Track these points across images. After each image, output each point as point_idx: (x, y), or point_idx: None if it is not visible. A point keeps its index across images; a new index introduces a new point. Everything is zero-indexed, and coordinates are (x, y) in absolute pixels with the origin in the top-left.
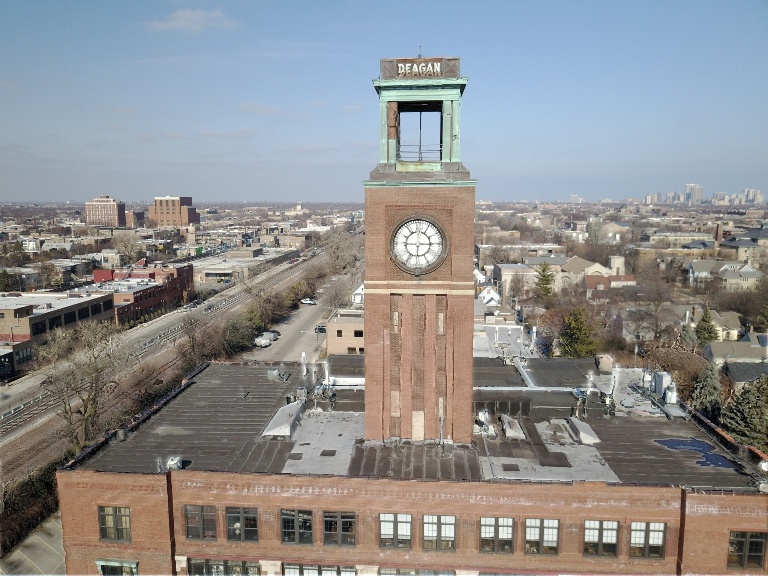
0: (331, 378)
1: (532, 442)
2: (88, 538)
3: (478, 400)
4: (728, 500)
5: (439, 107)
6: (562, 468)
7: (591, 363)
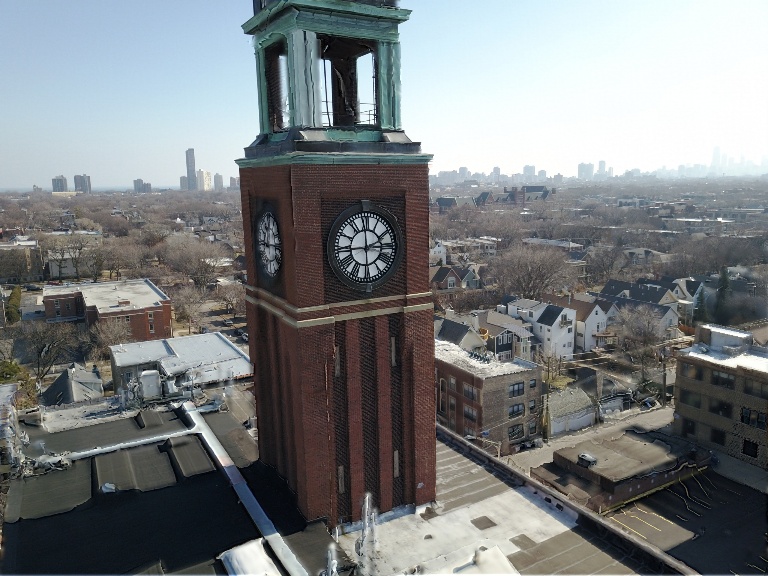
0: None
1: None
2: None
3: None
4: None
5: None
6: None
7: (27, 428)
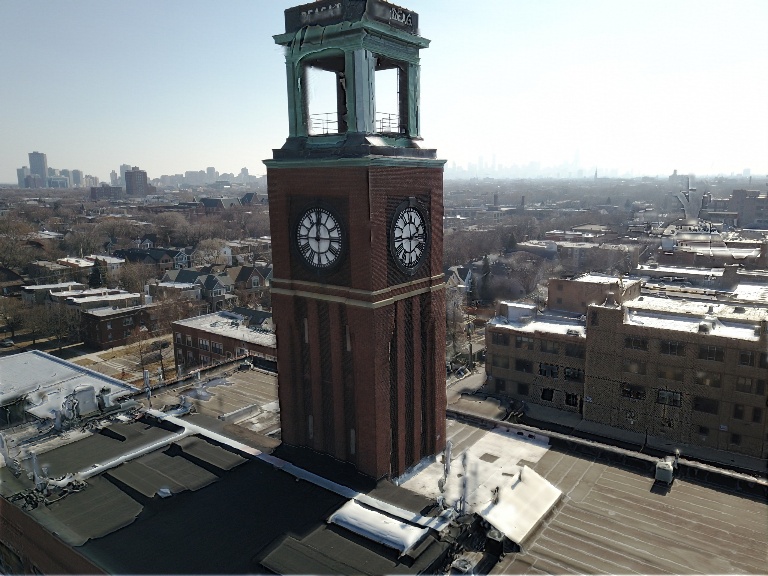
0: (405, 532)
1: None
2: None
3: (275, 439)
4: None
5: (341, 68)
6: None
7: None
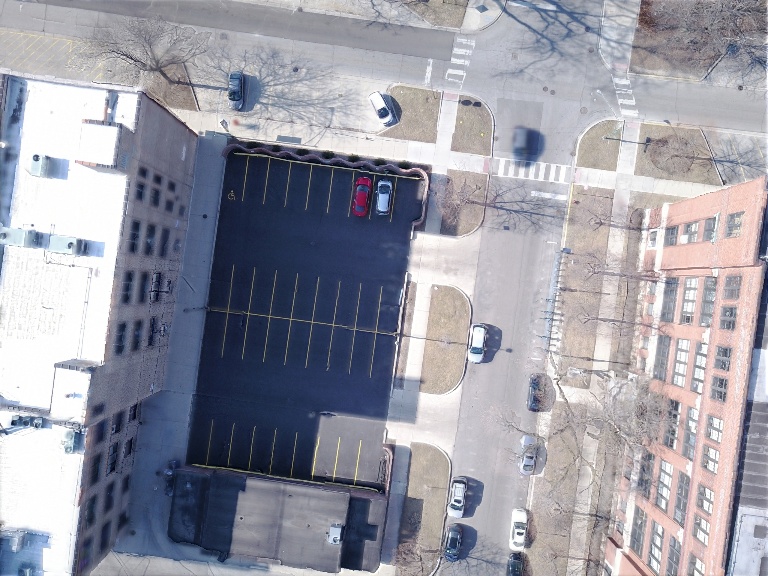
0: None
1: None
2: (731, 205)
3: None
4: None
5: None
6: (757, 572)
7: None
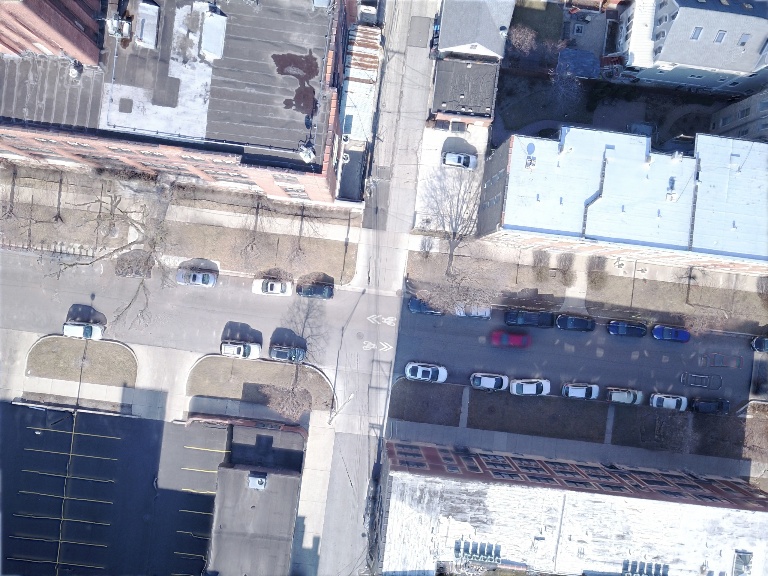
0: None
1: (160, 54)
2: None
3: None
4: (265, 169)
5: None
6: (167, 110)
7: None
